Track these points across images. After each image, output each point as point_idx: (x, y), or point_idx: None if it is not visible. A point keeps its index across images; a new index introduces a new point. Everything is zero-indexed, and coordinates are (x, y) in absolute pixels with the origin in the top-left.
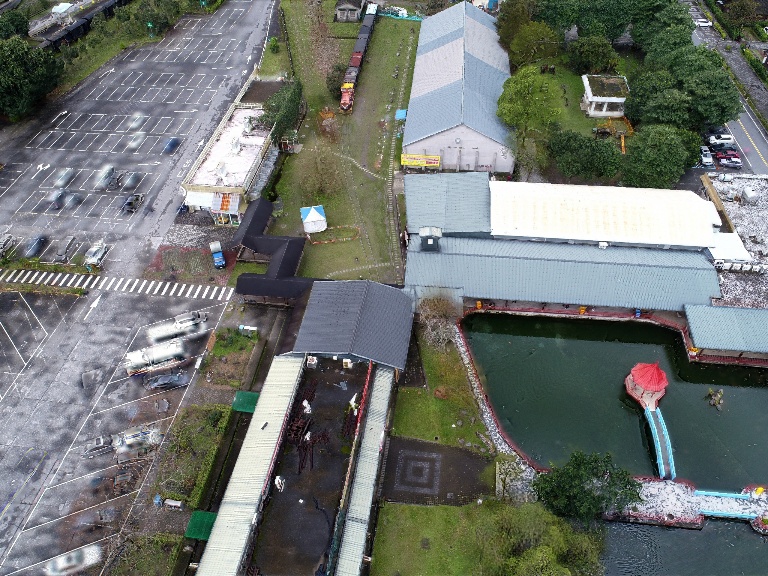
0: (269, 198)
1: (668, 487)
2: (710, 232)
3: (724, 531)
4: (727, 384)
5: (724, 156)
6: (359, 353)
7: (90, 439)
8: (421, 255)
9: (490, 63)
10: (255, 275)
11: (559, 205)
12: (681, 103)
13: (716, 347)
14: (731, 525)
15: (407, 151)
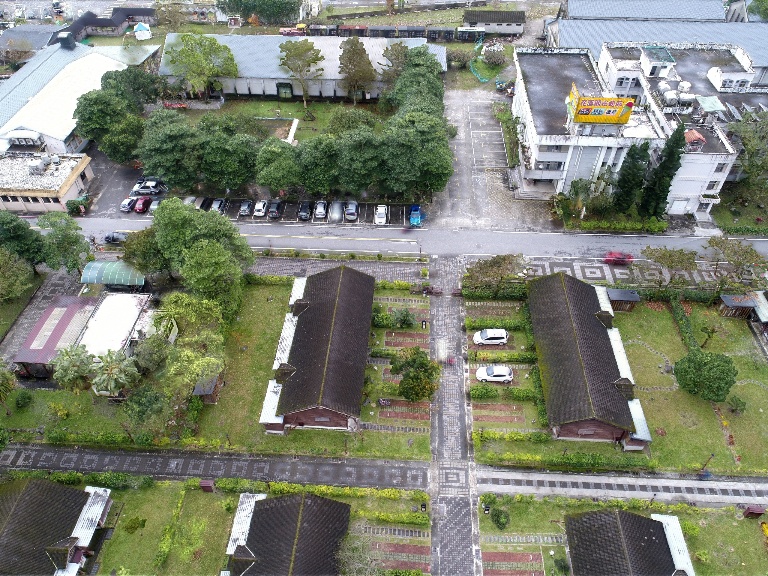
0: None
1: None
2: (2, 132)
3: None
4: None
5: None
6: (4, 33)
7: (27, 8)
8: None
9: None
10: (90, 16)
11: None
12: None
13: None
14: None
15: None
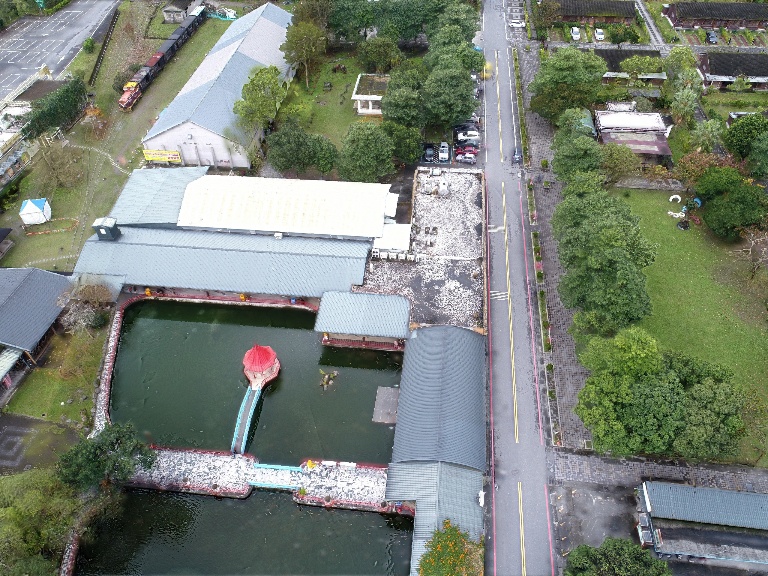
0: (9, 192)
1: (234, 460)
2: (380, 223)
3: (269, 501)
4: (365, 367)
5: (462, 152)
6: None
7: None
8: (97, 244)
9: (265, 63)
10: None
11: (247, 197)
12: (408, 100)
13: (333, 331)
14: (276, 495)
15: (148, 147)
